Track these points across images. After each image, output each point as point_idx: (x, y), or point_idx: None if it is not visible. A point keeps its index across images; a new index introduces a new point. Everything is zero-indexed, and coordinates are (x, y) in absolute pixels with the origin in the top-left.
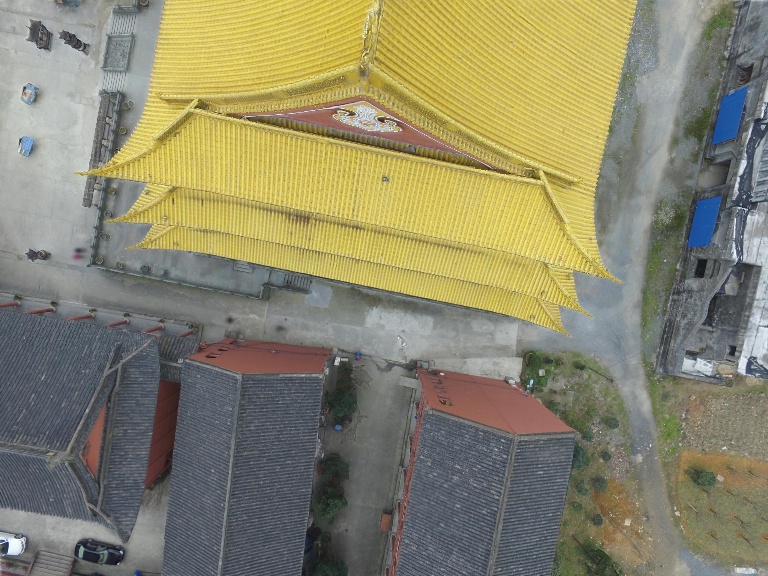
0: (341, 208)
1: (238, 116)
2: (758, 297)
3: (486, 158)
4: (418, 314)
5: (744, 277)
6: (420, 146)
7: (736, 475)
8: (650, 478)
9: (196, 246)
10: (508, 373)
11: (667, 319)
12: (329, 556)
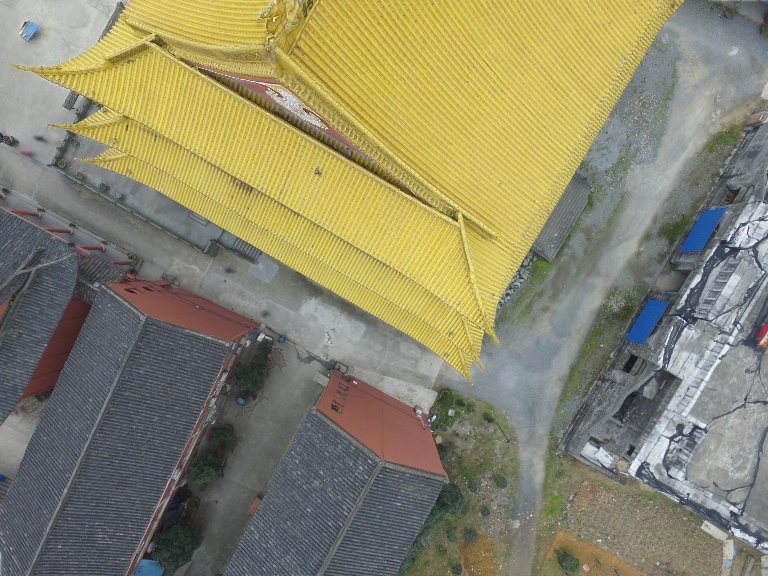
0: (270, 186)
1: (190, 64)
2: (670, 408)
3: (407, 183)
4: (353, 318)
5: (664, 385)
6: (357, 152)
7: (602, 570)
8: (521, 546)
9: (149, 180)
10: (420, 402)
11: (585, 401)
12: (188, 521)
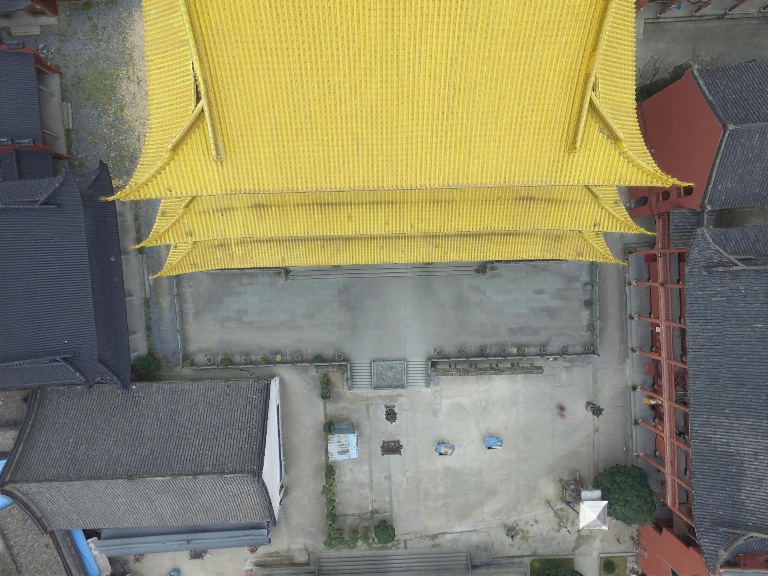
0: None
1: None
2: None
3: None
4: None
5: None
6: None
7: None
8: None
9: None
10: None
11: None
12: None
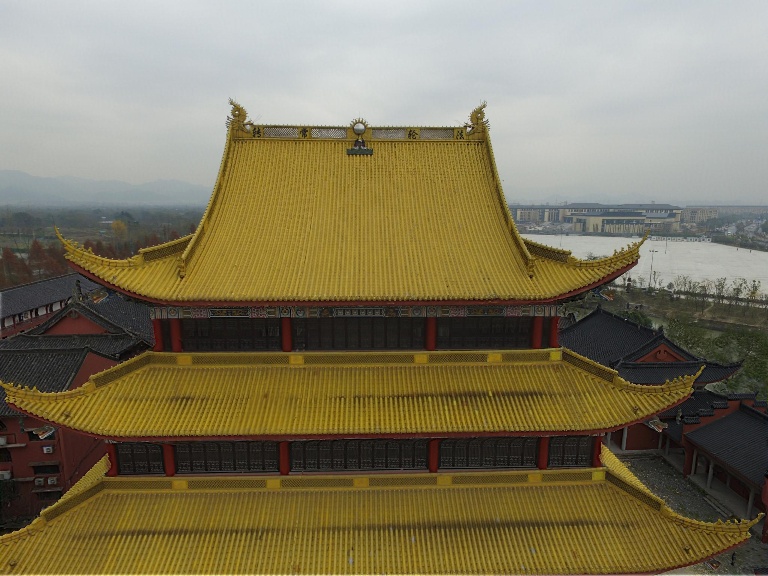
0: None
1: None
2: None
3: None
4: None
5: None
6: None
7: None
8: None
9: None
10: None
11: None
12: None
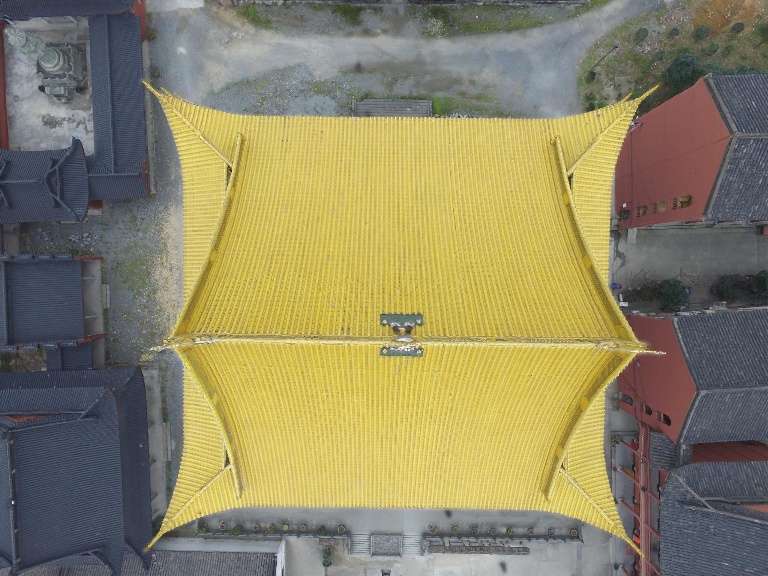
0: None
1: None
2: None
3: None
4: None
5: None
6: None
7: None
8: None
9: None
10: None
11: (532, 3)
12: None
